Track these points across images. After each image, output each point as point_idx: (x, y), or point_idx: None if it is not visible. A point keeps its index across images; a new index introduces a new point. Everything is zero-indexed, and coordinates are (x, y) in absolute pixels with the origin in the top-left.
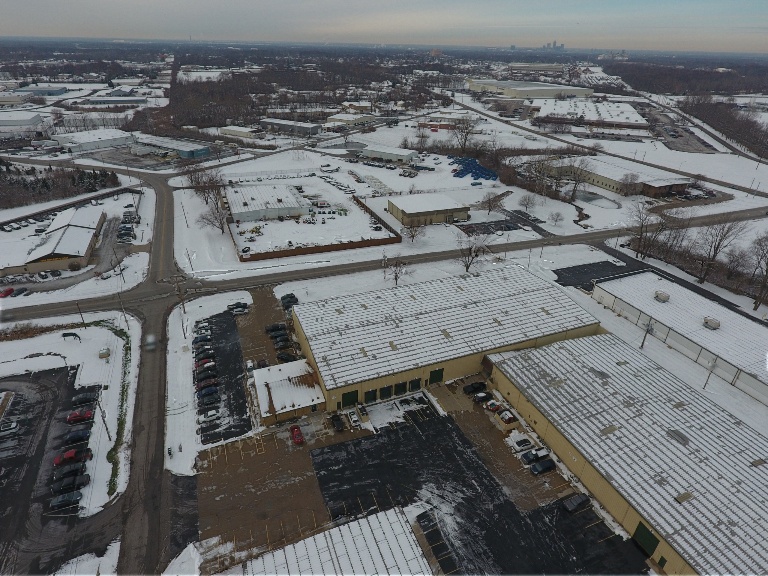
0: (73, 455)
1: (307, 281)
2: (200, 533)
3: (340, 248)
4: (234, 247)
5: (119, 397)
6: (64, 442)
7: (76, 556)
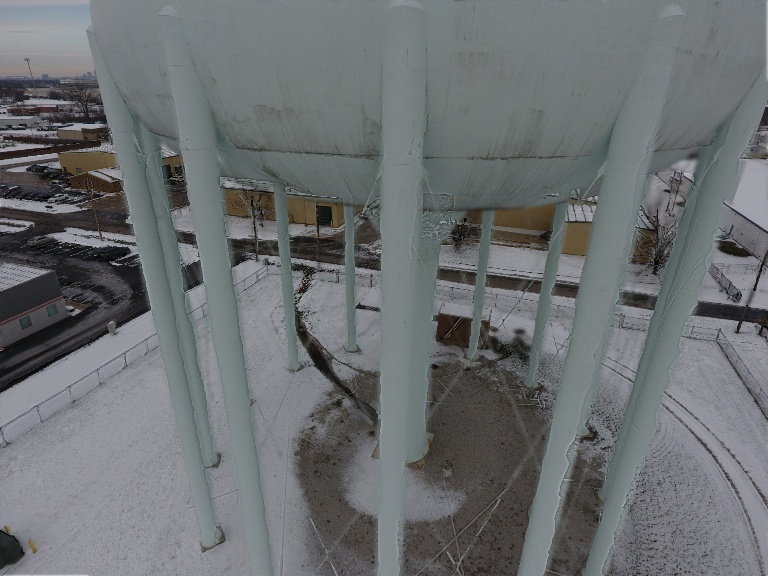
0: None
1: None
2: None
3: (44, 153)
4: None
5: None
6: None
7: (43, 235)
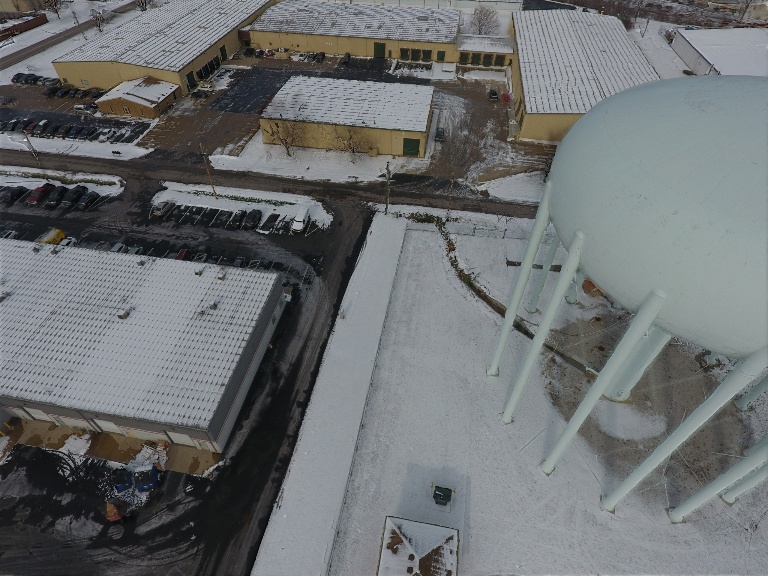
0: (43, 188)
1: (10, 68)
2: (206, 153)
3: None
4: None
5: None
6: (9, 200)
7: (152, 197)
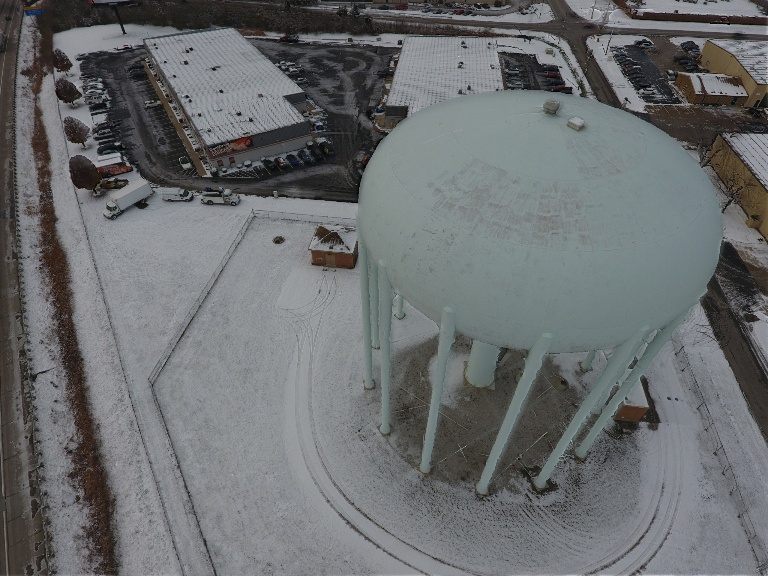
0: None
1: (701, 39)
2: None
3: (730, 22)
4: (621, 9)
5: (572, 73)
6: (550, 84)
7: None
